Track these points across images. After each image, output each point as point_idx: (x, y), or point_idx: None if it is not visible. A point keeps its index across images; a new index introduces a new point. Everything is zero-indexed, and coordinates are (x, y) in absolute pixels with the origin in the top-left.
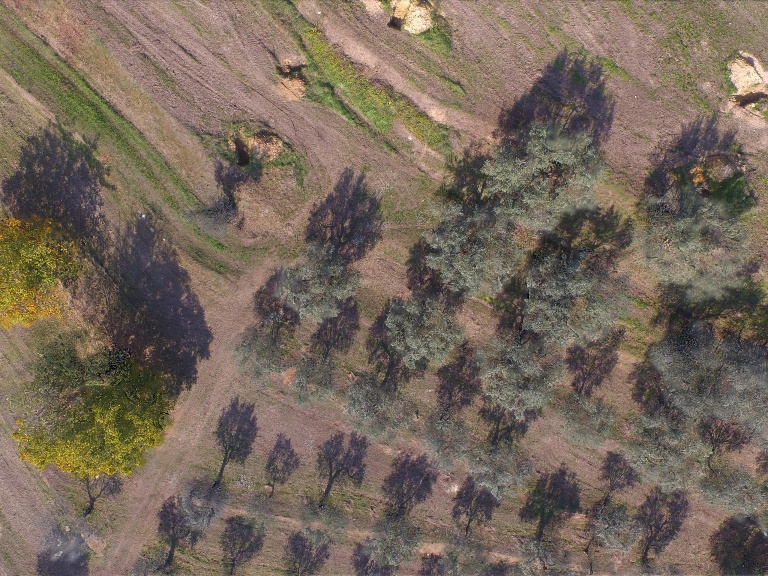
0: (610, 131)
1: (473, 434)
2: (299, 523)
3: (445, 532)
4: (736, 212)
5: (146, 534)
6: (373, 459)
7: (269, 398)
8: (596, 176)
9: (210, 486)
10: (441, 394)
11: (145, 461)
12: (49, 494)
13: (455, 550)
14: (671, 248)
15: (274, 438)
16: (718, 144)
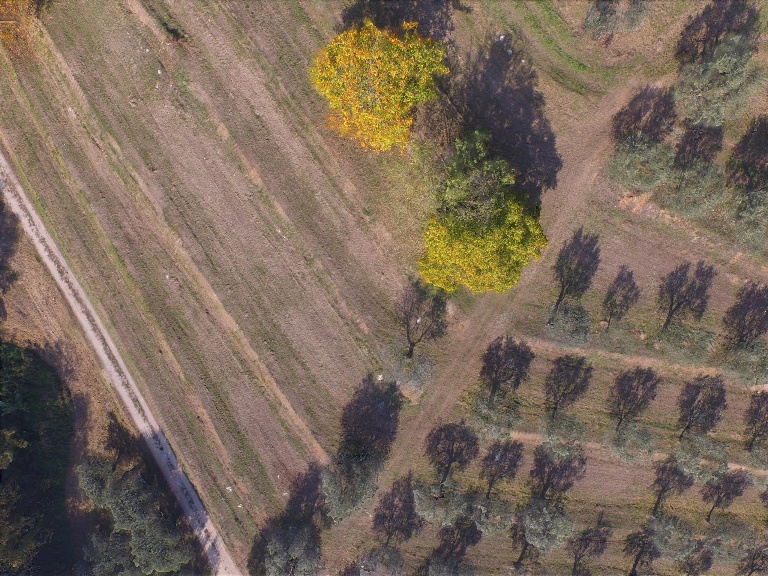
0: None
1: None
2: (632, 360)
3: None
4: None
5: (467, 379)
6: (717, 290)
7: (615, 228)
8: None
9: (543, 324)
10: None
11: (474, 301)
12: (363, 342)
13: None
14: None
15: (616, 271)
16: None
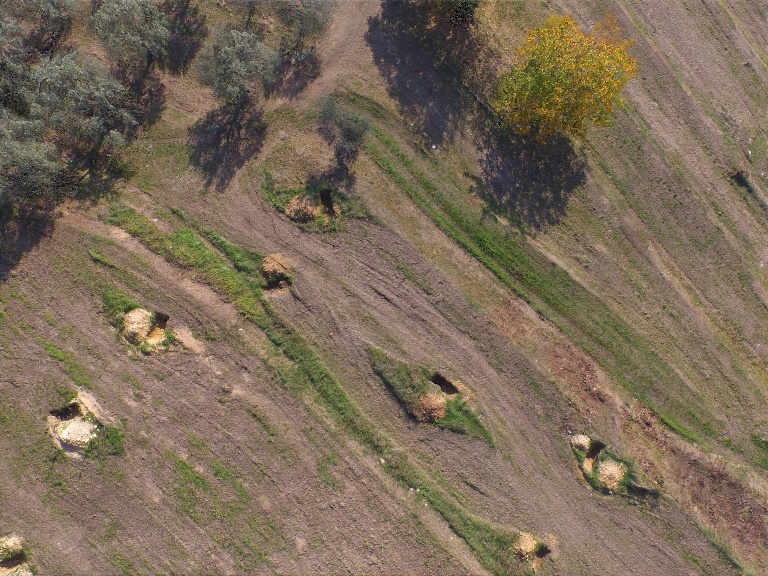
0: None
1: None
2: None
3: None
4: None
5: None
6: None
7: None
8: None
9: None
10: None
11: None
12: None
13: None
14: None
15: None
16: None
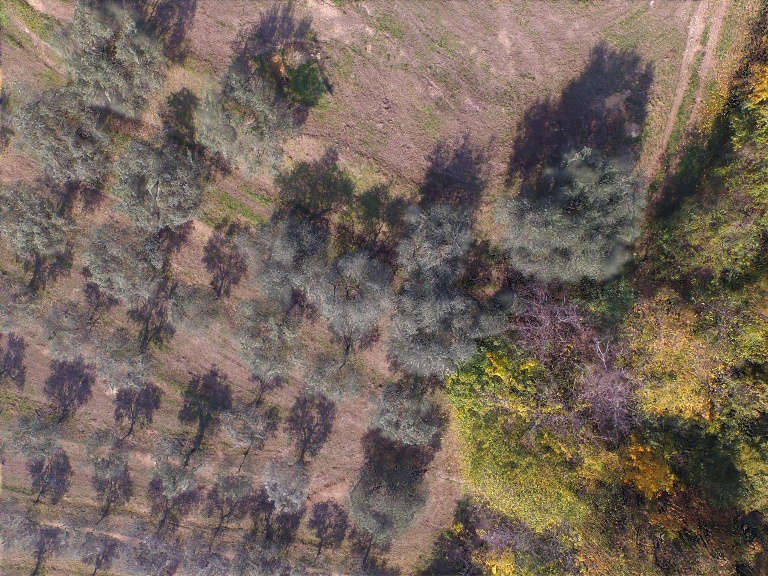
0: (194, 19)
1: (124, 334)
2: None
3: (109, 435)
4: (313, 99)
5: None
6: (32, 361)
7: None
8: (183, 64)
9: None
10: (88, 293)
11: None
12: None
13: (122, 454)
14: (248, 133)
15: None
16: (294, 32)
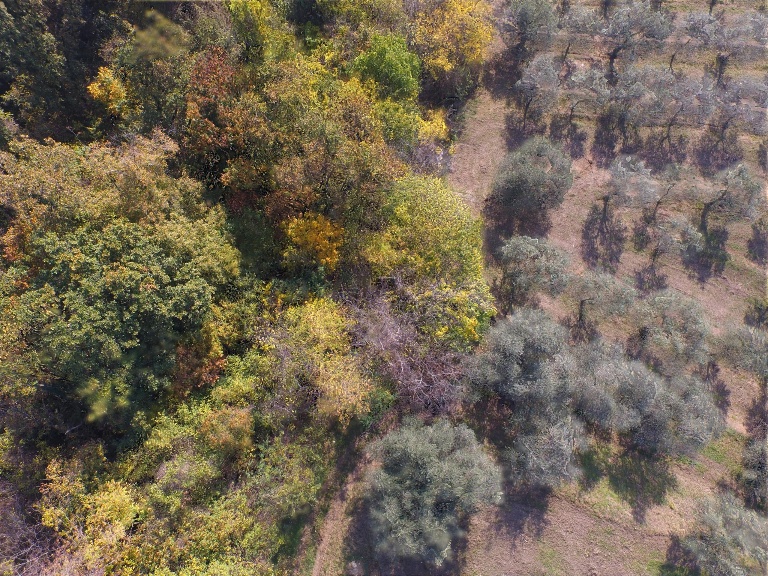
0: None
1: None
2: None
3: None
4: (664, 572)
5: None
6: None
7: None
8: None
9: None
10: None
11: None
12: None
13: None
14: None
15: None
16: None
